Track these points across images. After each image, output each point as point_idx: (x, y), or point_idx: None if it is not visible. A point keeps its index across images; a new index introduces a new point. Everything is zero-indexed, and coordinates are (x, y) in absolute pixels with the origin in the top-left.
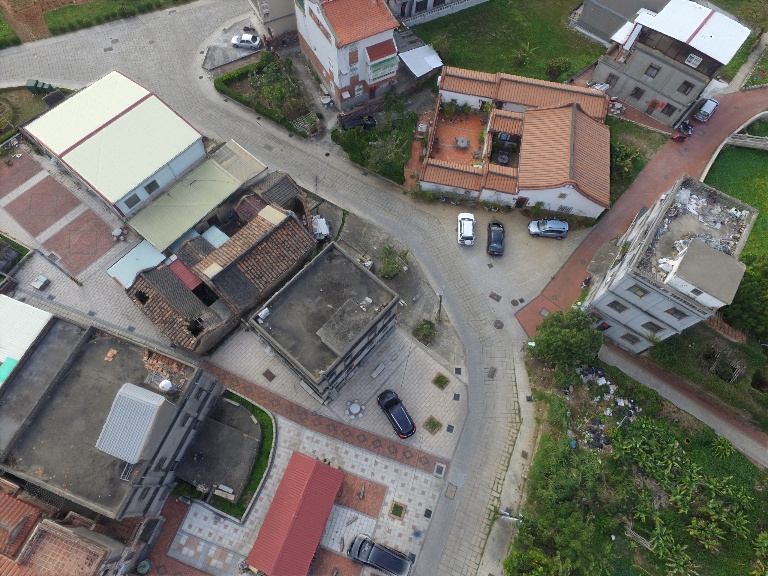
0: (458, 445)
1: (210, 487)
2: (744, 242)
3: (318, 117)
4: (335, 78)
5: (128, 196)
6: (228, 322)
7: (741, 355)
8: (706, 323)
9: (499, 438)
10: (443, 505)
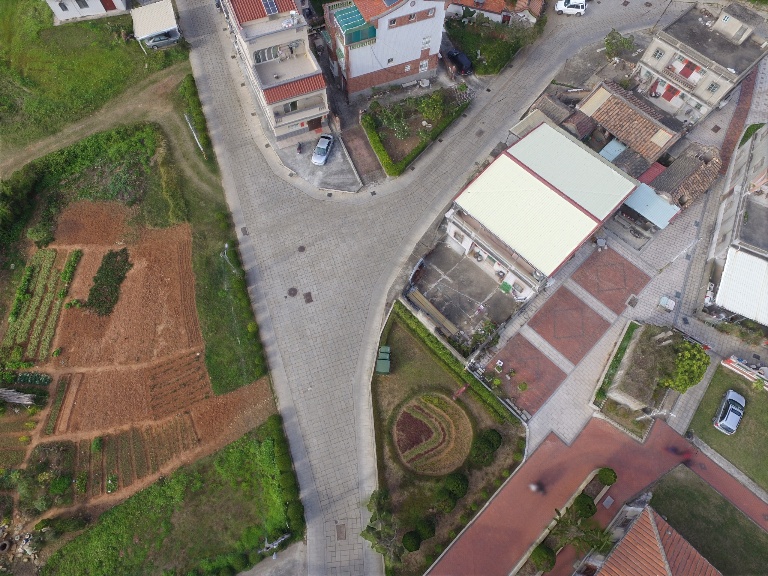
0: None
1: None
2: None
3: None
4: (433, 49)
5: None
6: None
7: None
8: None
9: None
10: None
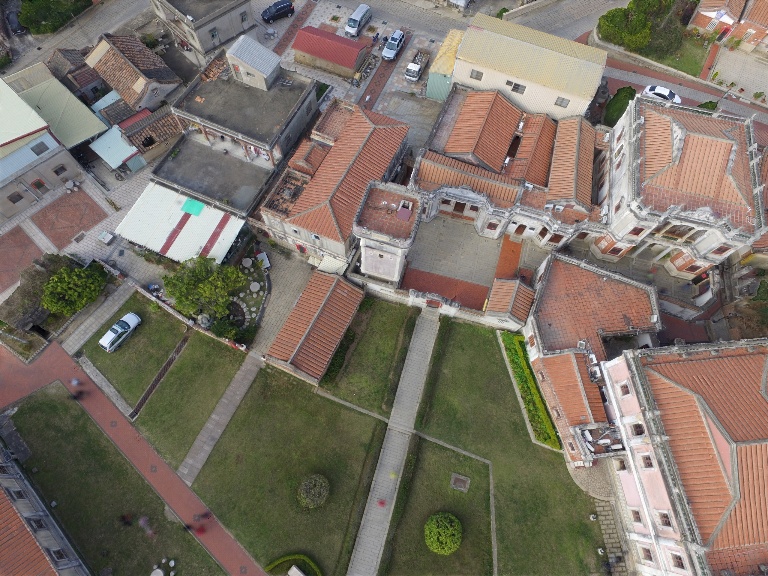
0: None
1: None
2: None
3: None
4: None
5: None
6: None
7: None
8: None
9: None
10: (335, 0)
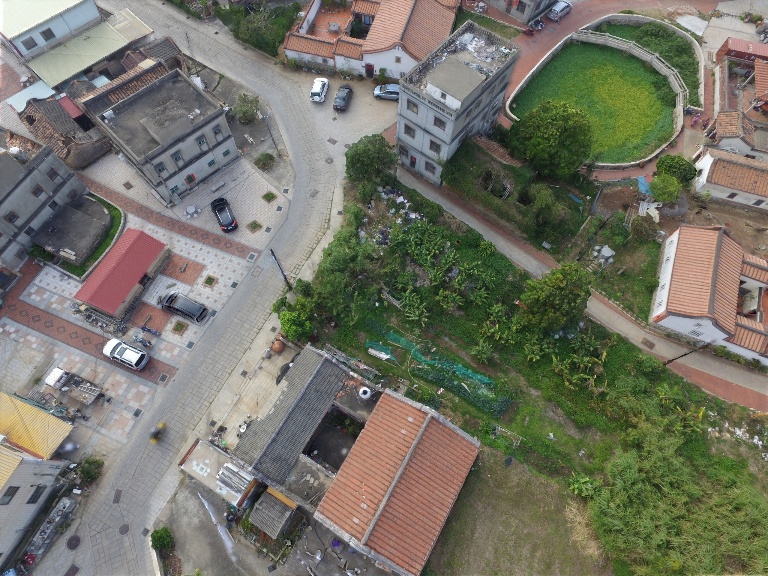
0: (272, 241)
1: (57, 249)
2: (500, 68)
3: (214, 3)
4: None
5: (24, 37)
6: (98, 142)
7: (510, 175)
8: (485, 150)
9: (307, 238)
10: (248, 280)
